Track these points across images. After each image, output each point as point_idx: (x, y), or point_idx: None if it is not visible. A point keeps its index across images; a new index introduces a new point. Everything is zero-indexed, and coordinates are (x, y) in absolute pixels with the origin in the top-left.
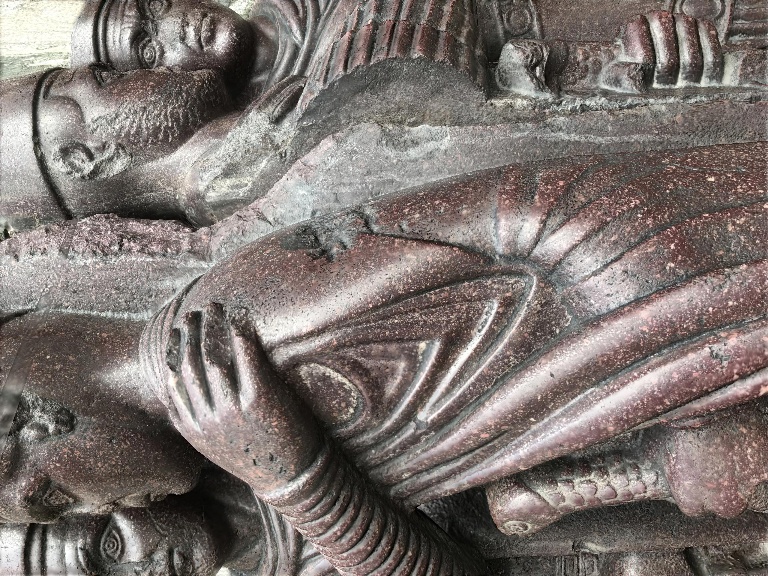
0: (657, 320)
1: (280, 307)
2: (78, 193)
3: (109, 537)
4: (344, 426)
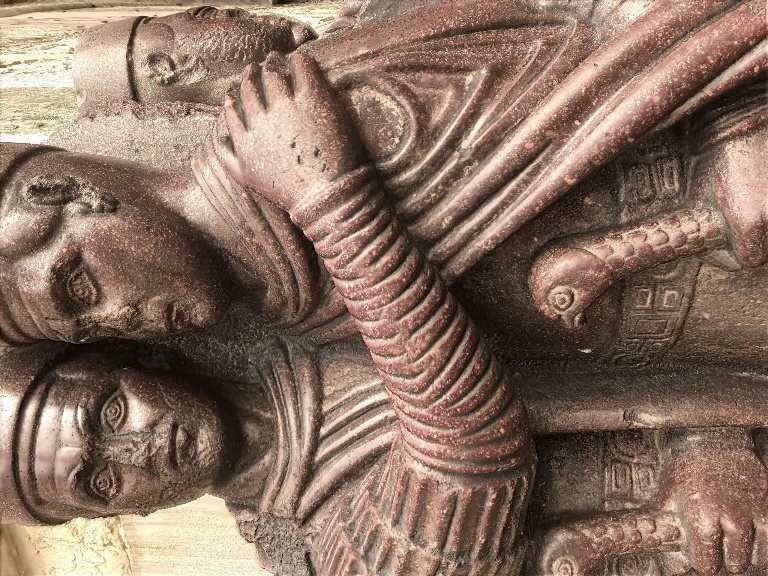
0: None
1: (339, 44)
2: (155, 97)
3: (113, 403)
4: (388, 159)
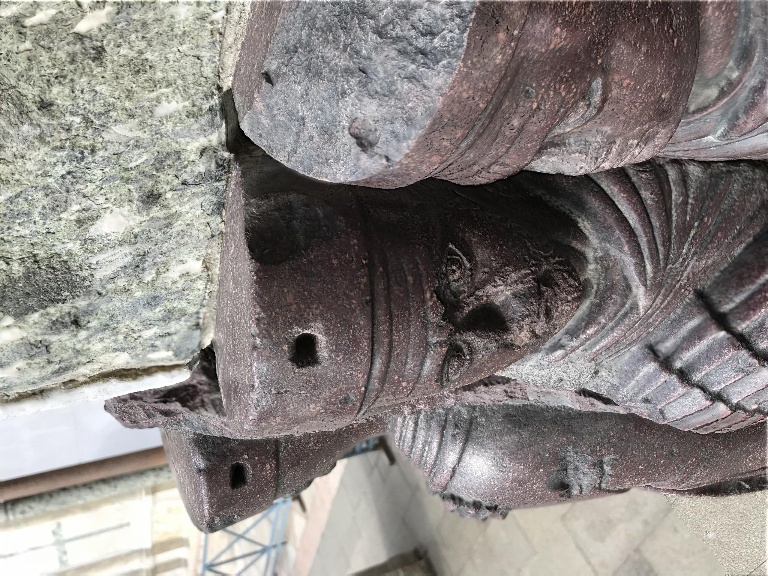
0: None
1: None
2: None
3: None
4: None
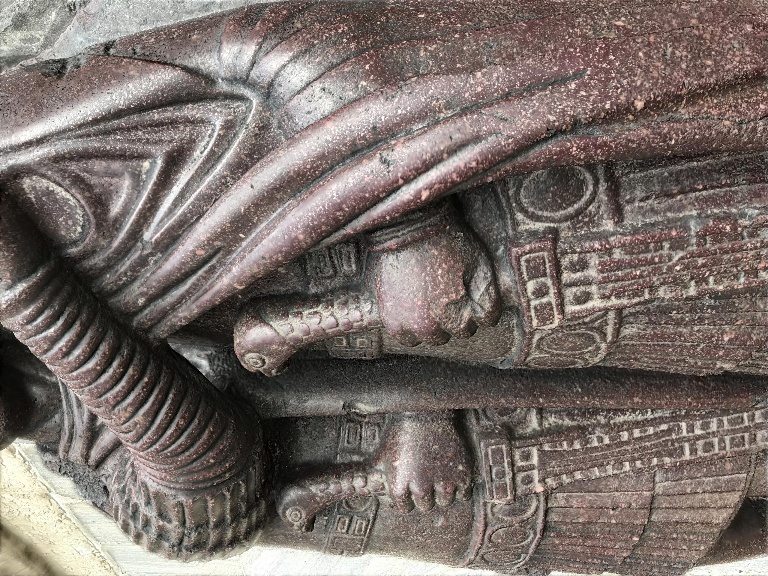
0: (339, 129)
1: (3, 118)
2: None
3: None
4: (74, 246)
